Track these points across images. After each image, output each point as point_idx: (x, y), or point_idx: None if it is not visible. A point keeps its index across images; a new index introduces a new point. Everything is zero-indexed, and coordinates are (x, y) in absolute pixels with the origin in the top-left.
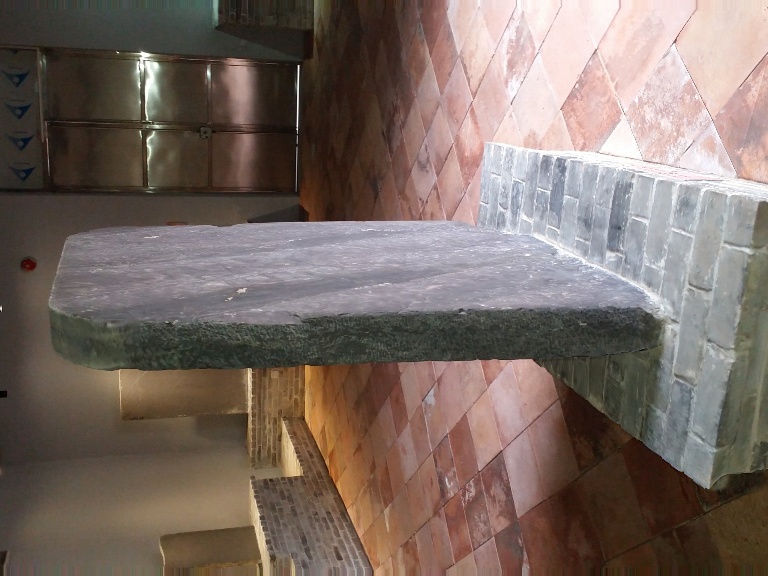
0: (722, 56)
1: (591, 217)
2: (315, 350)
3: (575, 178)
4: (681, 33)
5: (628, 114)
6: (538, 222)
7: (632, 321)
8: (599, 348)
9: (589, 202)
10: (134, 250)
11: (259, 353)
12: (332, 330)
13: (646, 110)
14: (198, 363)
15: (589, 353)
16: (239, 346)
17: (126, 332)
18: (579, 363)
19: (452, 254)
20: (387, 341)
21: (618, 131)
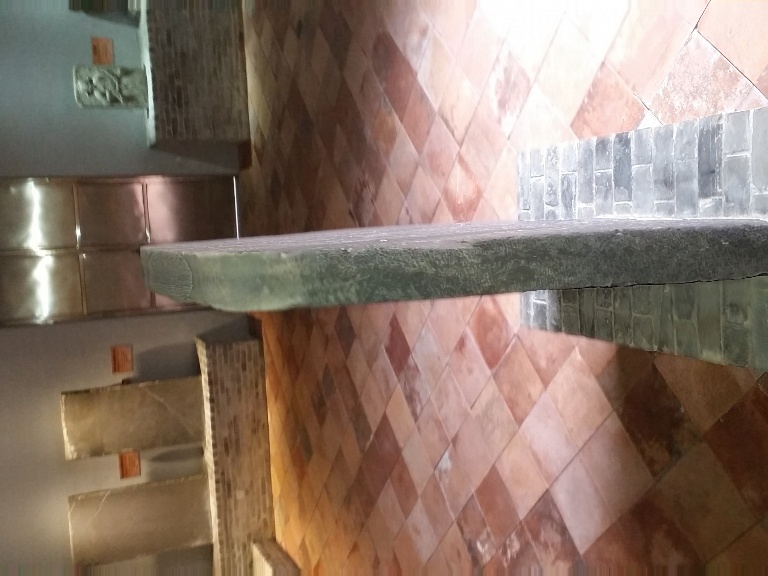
0: (754, 24)
1: (672, 175)
2: (487, 277)
3: (644, 145)
4: (702, 17)
5: (653, 107)
6: (602, 203)
7: (766, 239)
8: (741, 269)
9: (667, 161)
10: (226, 243)
11: (435, 281)
12: (503, 254)
13: (674, 98)
14: (375, 296)
15: (733, 275)
16: (416, 274)
17: (302, 261)
18: (682, 324)
19: (543, 225)
20: (553, 266)
21: (644, 126)
